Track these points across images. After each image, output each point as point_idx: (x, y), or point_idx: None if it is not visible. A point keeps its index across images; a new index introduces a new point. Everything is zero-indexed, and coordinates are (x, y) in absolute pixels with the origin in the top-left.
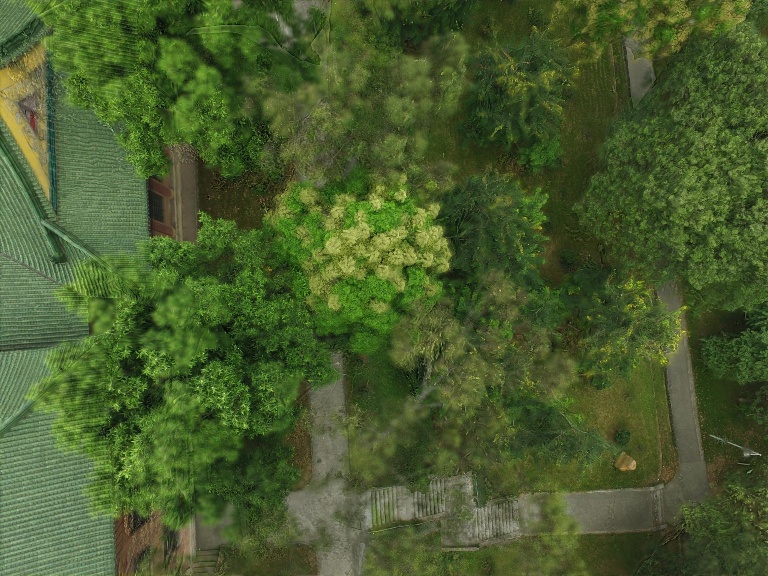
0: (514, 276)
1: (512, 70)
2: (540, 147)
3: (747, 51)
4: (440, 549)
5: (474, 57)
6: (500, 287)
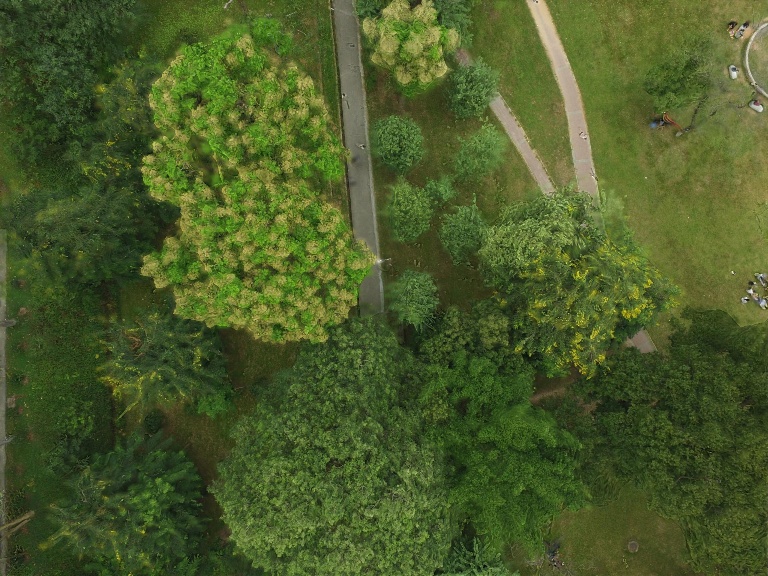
0: None
1: (117, 367)
2: (205, 403)
3: (350, 356)
4: None
5: None
6: (132, 569)
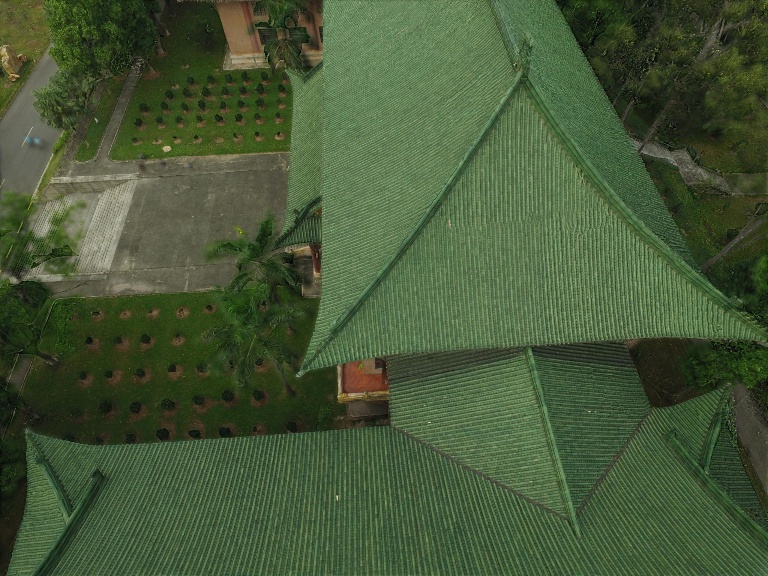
0: (684, 24)
1: None
2: None
3: None
4: (684, 182)
5: (607, 9)
6: None
